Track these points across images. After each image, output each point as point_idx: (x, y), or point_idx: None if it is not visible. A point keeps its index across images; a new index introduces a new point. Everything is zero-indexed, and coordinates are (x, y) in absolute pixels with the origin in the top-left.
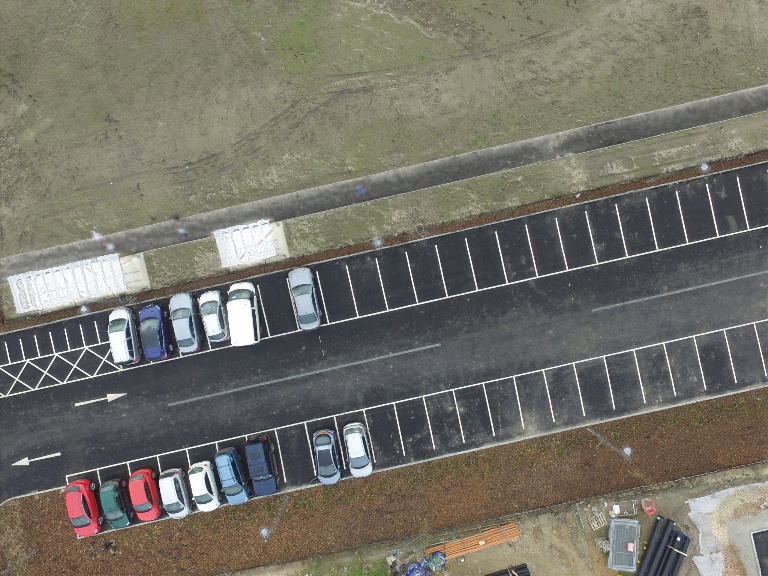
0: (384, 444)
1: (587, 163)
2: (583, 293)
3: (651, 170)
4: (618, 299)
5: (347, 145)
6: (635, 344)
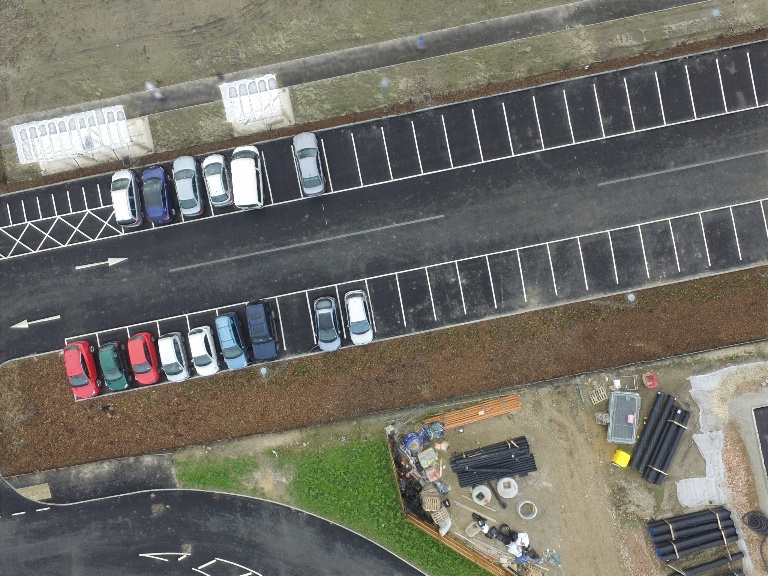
0: (385, 314)
1: (596, 35)
2: (589, 166)
3: (660, 43)
4: (624, 173)
5: (355, 12)
6: (640, 219)
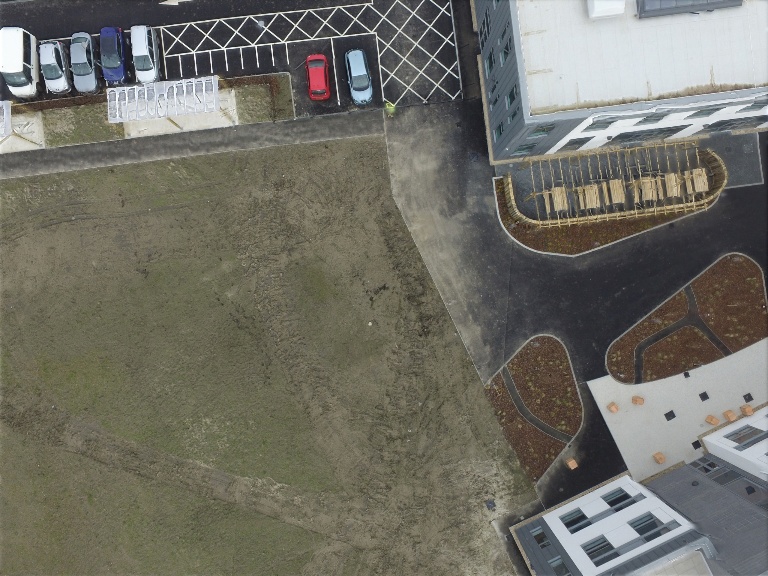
0: None
1: None
2: None
3: None
4: None
5: None
6: None
